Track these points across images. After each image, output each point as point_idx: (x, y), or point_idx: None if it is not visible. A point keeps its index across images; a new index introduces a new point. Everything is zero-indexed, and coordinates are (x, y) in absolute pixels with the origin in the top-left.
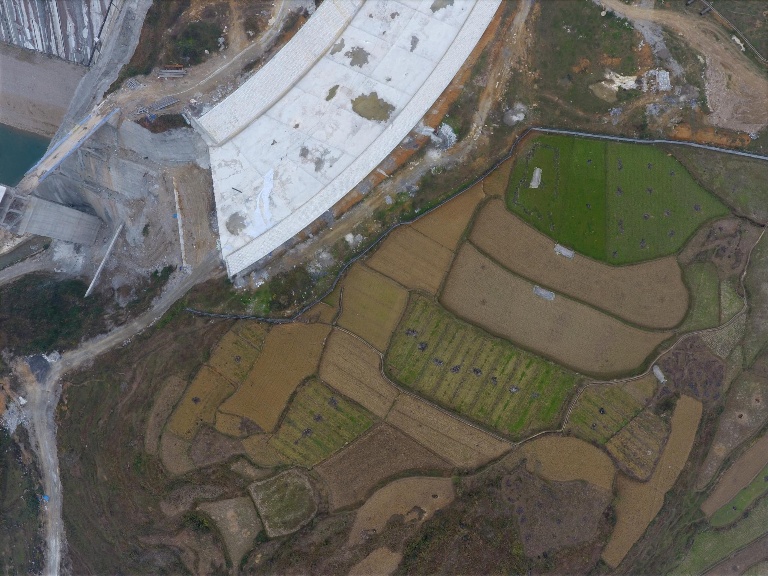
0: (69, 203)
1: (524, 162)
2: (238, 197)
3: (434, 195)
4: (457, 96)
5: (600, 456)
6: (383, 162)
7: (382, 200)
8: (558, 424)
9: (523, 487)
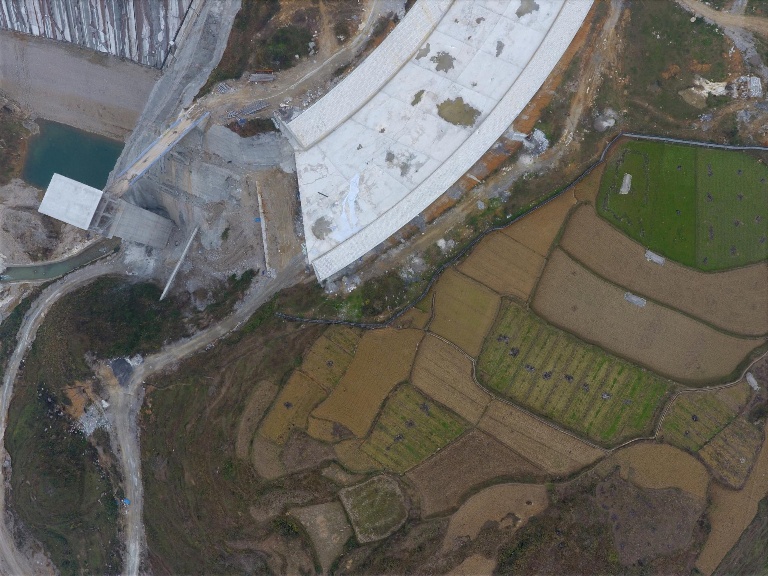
0: (143, 206)
1: (614, 168)
2: (324, 201)
3: (525, 201)
4: (548, 102)
5: (694, 463)
6: (473, 167)
7: (474, 205)
8: (650, 431)
9: (617, 494)
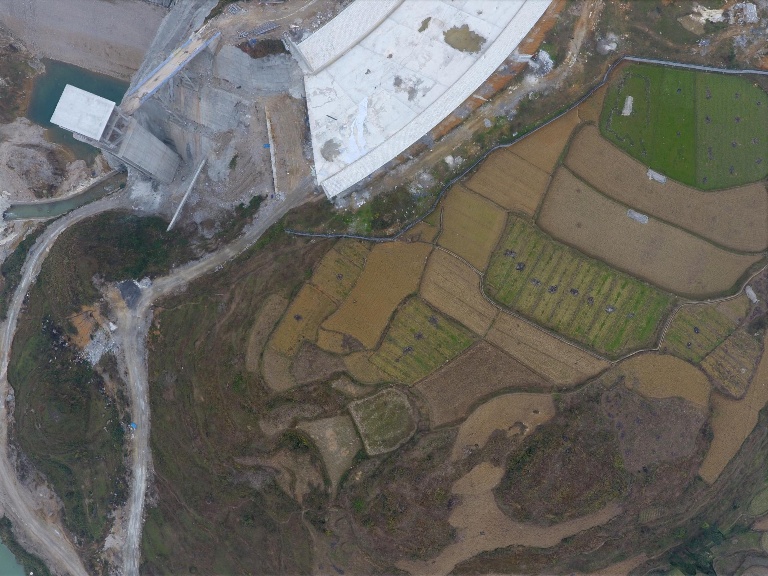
0: None
1: (616, 90)
2: (333, 124)
3: (531, 120)
4: (552, 25)
5: (696, 374)
6: (479, 88)
7: (481, 123)
8: (653, 343)
9: (622, 403)
